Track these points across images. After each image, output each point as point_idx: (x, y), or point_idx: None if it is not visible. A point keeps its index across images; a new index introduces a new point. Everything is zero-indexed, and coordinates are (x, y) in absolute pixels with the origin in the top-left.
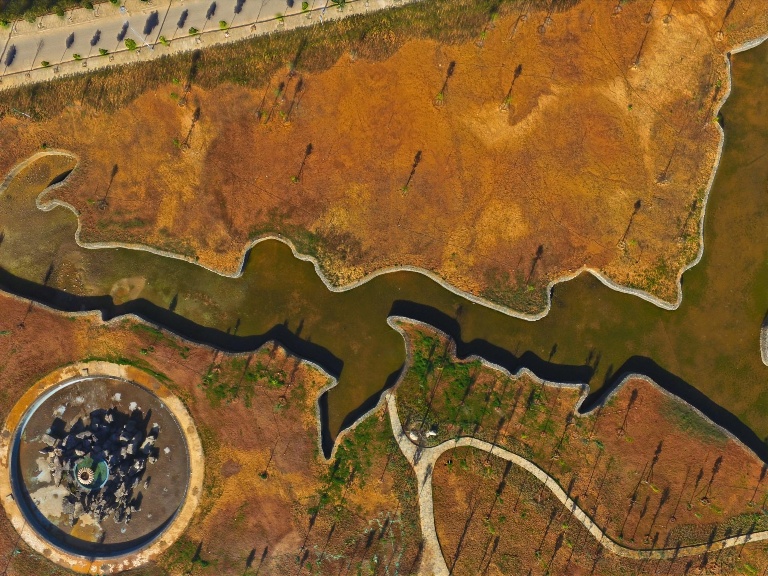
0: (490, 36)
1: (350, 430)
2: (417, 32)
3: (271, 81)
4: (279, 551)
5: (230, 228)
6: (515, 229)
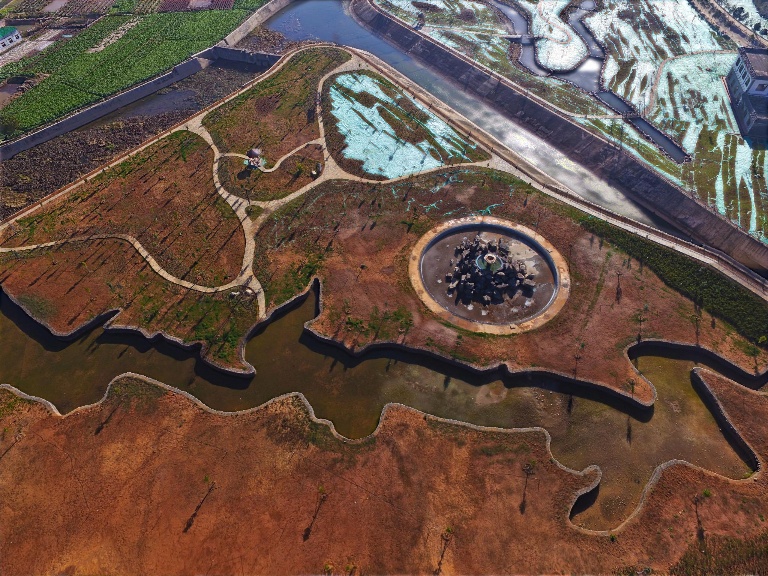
0: None
1: (297, 295)
2: None
3: None
4: (354, 230)
5: (394, 447)
6: (114, 450)
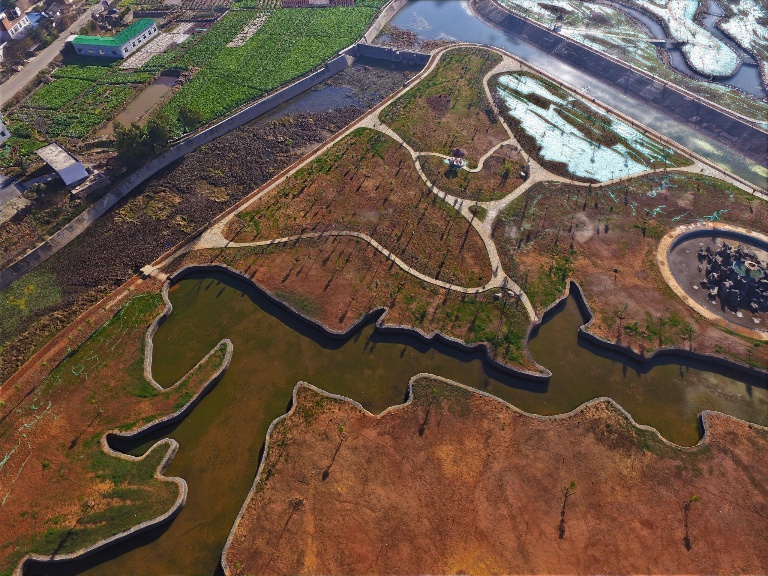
0: None
1: (560, 298)
2: None
3: None
4: (589, 233)
5: (733, 456)
6: (447, 452)
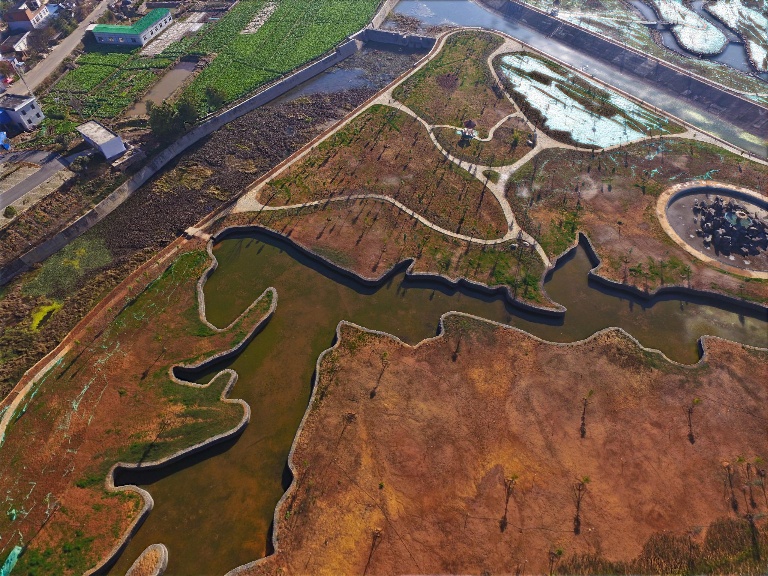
0: (543, 568)
1: (571, 247)
2: (629, 572)
3: (767, 509)
4: (594, 191)
5: (729, 370)
6: (478, 374)
